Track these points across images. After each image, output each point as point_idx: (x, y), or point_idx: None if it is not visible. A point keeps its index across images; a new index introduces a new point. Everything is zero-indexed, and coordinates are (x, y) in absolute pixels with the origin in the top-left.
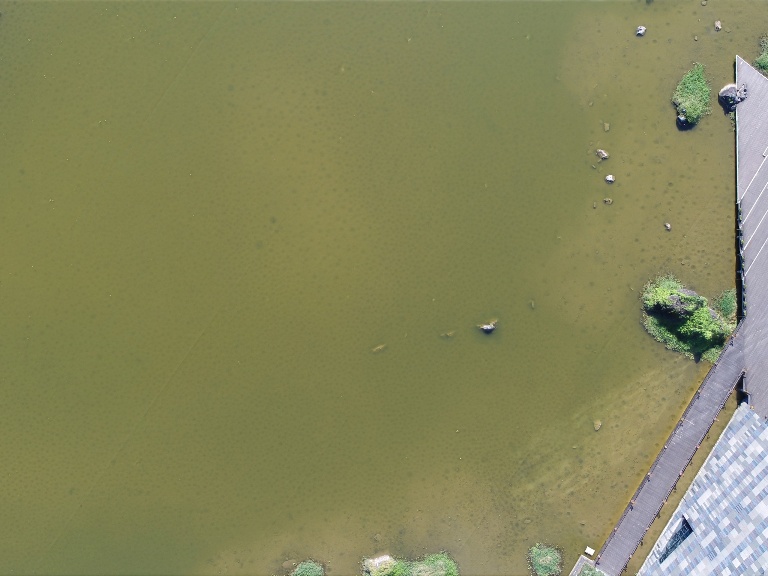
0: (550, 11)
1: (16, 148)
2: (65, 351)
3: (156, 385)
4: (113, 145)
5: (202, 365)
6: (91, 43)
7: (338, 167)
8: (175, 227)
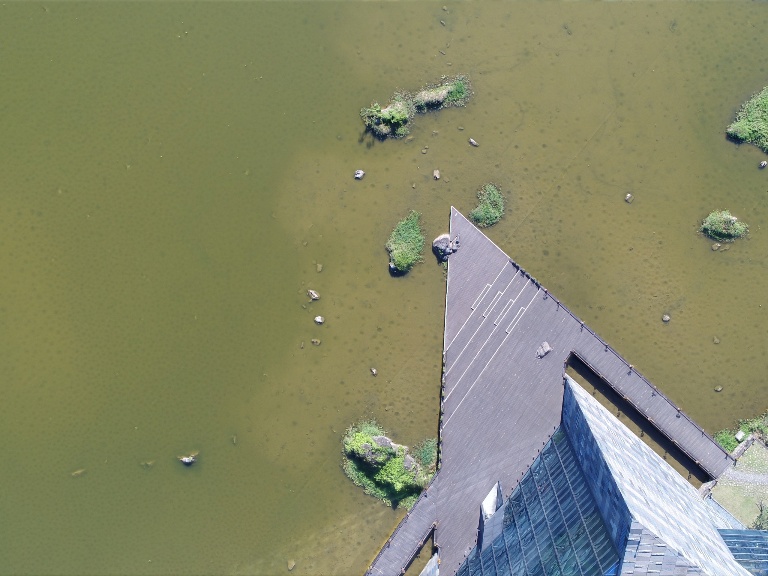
0: (271, 148)
1: None
2: None
3: None
4: None
5: None
6: None
7: (49, 289)
8: None
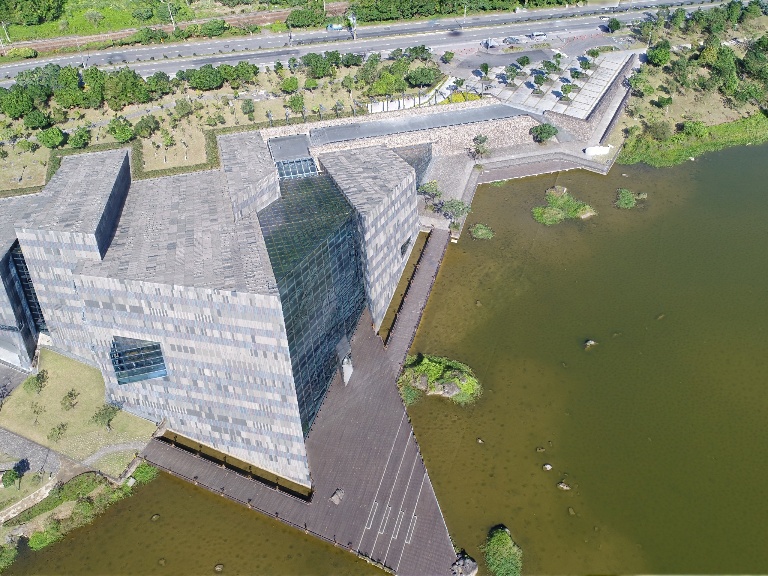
0: None
1: None
2: None
3: None
4: None
5: None
6: None
7: None
8: None
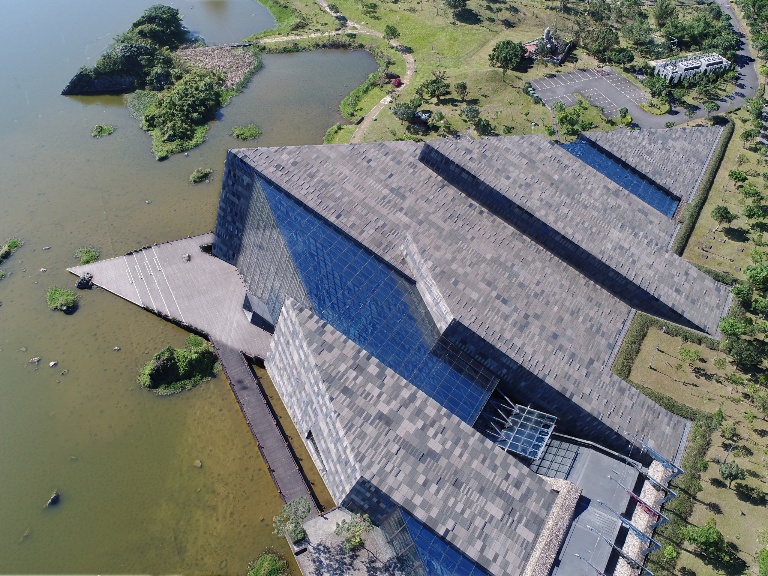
0: None
1: None
2: None
3: None
4: None
5: None
6: None
7: None
8: None
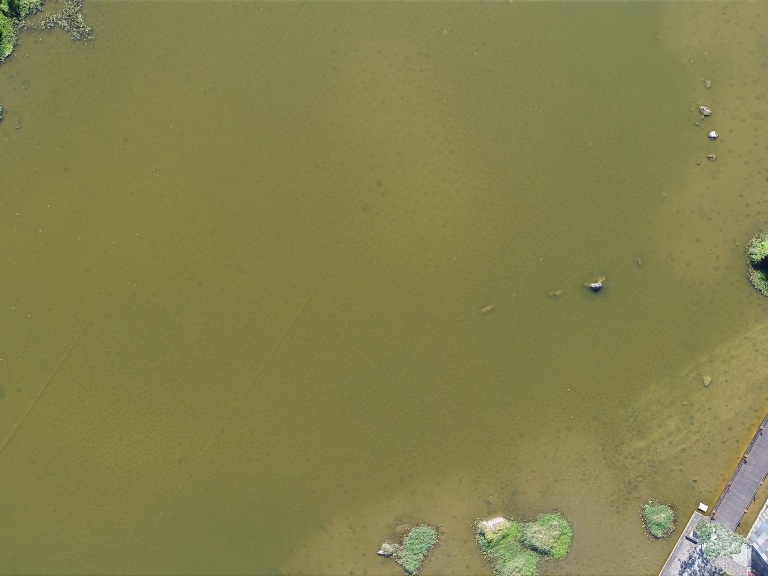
0: None
1: (119, 116)
2: (172, 319)
3: (264, 351)
4: (217, 111)
5: (310, 330)
6: (193, 10)
7: (443, 129)
8: (280, 192)
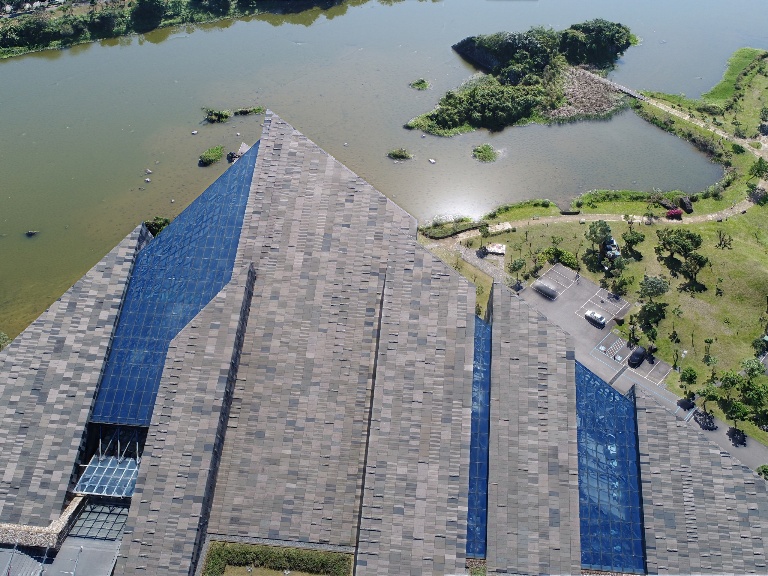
0: None
1: None
2: None
3: None
4: None
5: None
6: None
7: None
8: None
